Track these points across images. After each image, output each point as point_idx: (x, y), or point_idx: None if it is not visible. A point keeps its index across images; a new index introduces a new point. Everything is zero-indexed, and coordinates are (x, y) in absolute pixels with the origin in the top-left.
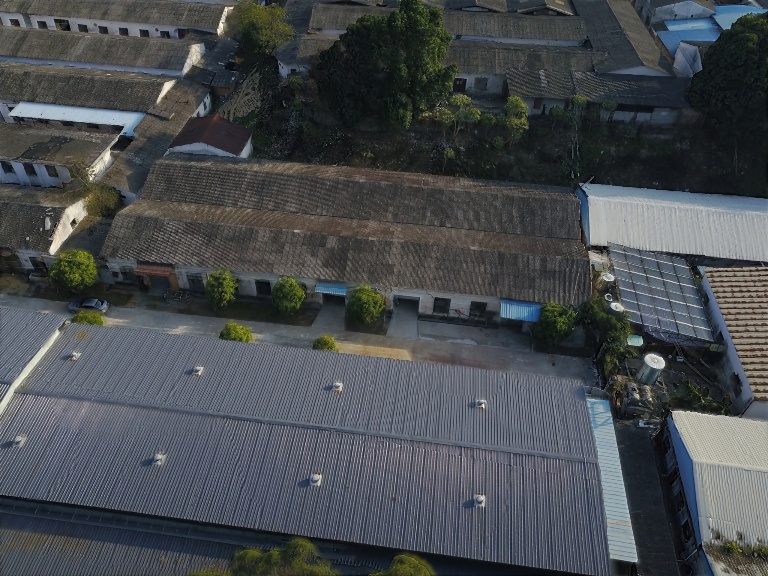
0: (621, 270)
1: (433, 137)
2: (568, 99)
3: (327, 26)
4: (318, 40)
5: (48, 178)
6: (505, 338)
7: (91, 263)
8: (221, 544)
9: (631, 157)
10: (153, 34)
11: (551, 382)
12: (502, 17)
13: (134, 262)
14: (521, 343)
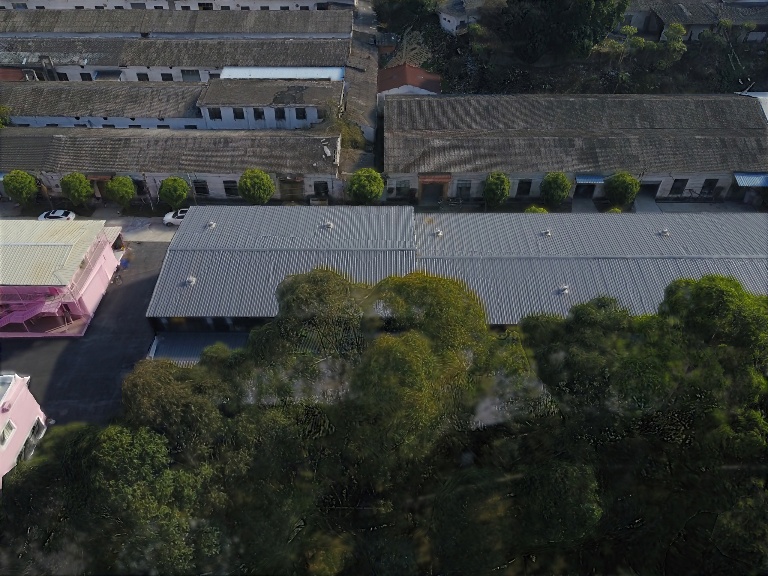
0: None
1: (599, 67)
2: (714, 24)
3: None
4: None
5: (295, 121)
6: (734, 208)
7: (379, 178)
8: None
9: (767, 70)
10: None
11: None
12: None
13: (414, 175)
14: (748, 210)
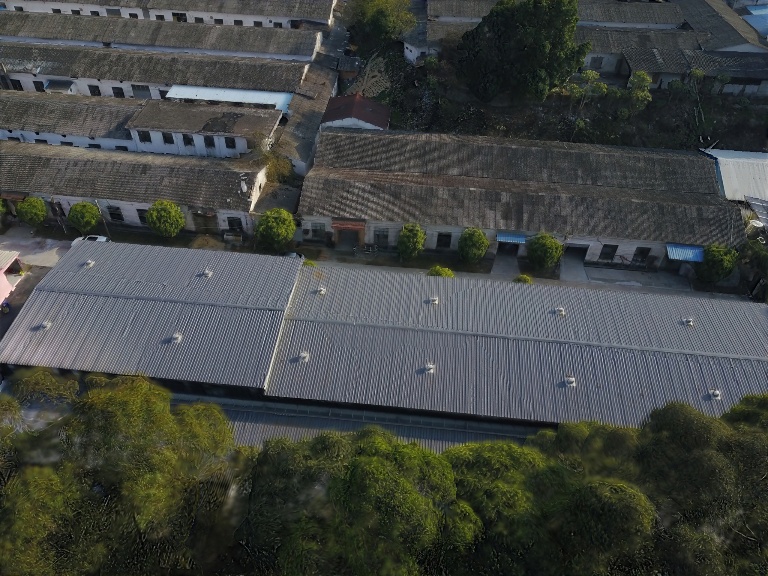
0: (765, 218)
1: (559, 111)
2: (685, 73)
3: (444, 13)
4: (444, 25)
5: (225, 150)
6: (666, 280)
7: (291, 220)
8: (498, 436)
9: (741, 126)
10: (266, 25)
11: (741, 305)
12: (603, 3)
13: (328, 219)
14: (681, 284)
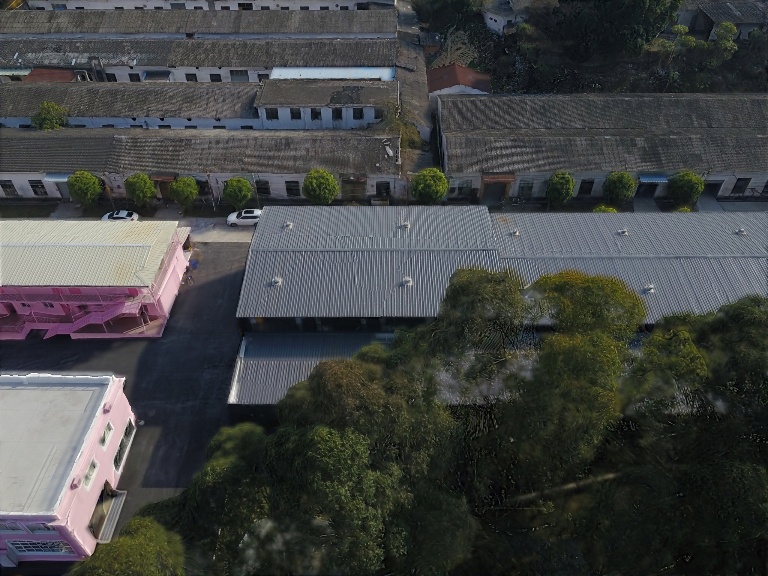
0: None
1: (648, 66)
2: (764, 23)
3: None
4: None
5: (352, 121)
6: None
7: None
8: None
9: None
10: None
11: None
12: None
13: (477, 175)
14: None
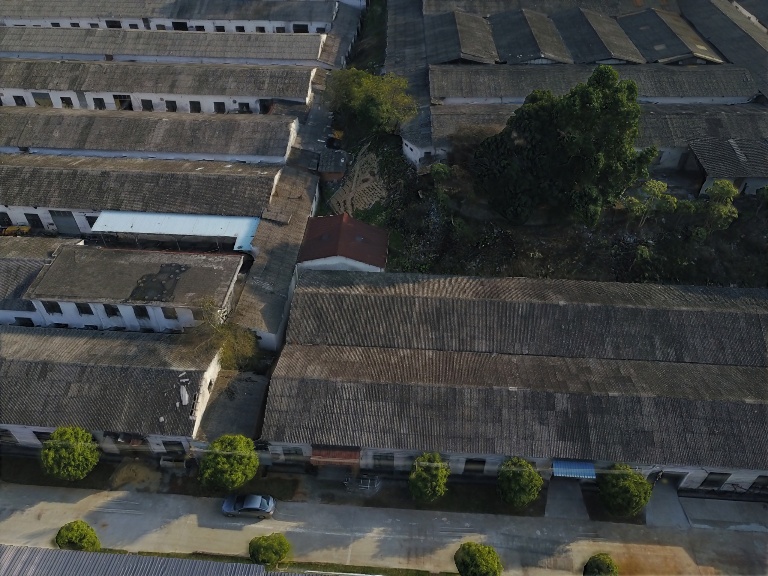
0: None
1: (612, 229)
2: None
3: (451, 94)
4: (452, 115)
5: (163, 320)
6: None
7: (252, 451)
8: None
9: None
10: (230, 106)
11: None
12: (652, 72)
13: (306, 444)
14: None
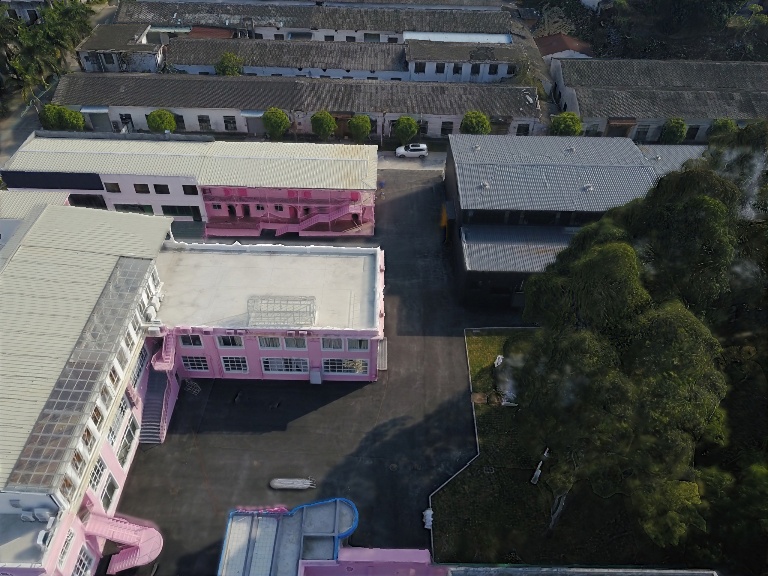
0: None
1: (725, 40)
2: None
3: None
4: None
5: (487, 76)
6: None
7: None
8: None
9: None
10: None
11: None
12: None
13: (604, 120)
14: None
